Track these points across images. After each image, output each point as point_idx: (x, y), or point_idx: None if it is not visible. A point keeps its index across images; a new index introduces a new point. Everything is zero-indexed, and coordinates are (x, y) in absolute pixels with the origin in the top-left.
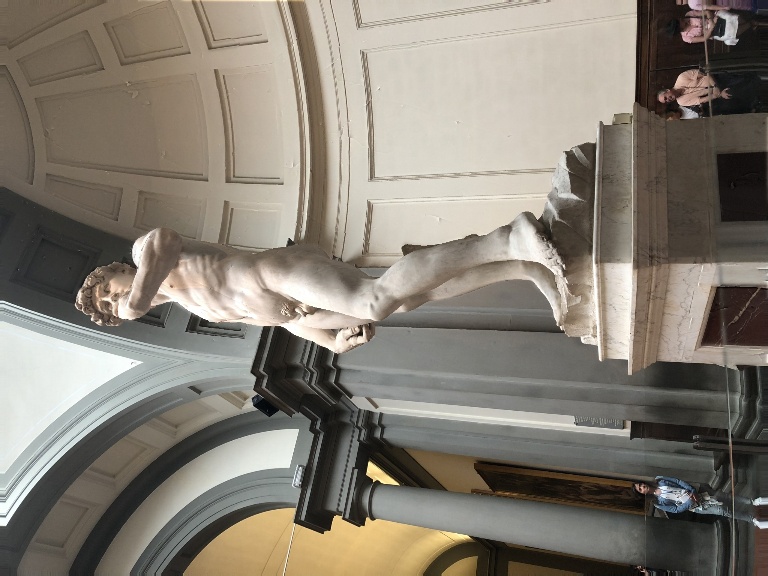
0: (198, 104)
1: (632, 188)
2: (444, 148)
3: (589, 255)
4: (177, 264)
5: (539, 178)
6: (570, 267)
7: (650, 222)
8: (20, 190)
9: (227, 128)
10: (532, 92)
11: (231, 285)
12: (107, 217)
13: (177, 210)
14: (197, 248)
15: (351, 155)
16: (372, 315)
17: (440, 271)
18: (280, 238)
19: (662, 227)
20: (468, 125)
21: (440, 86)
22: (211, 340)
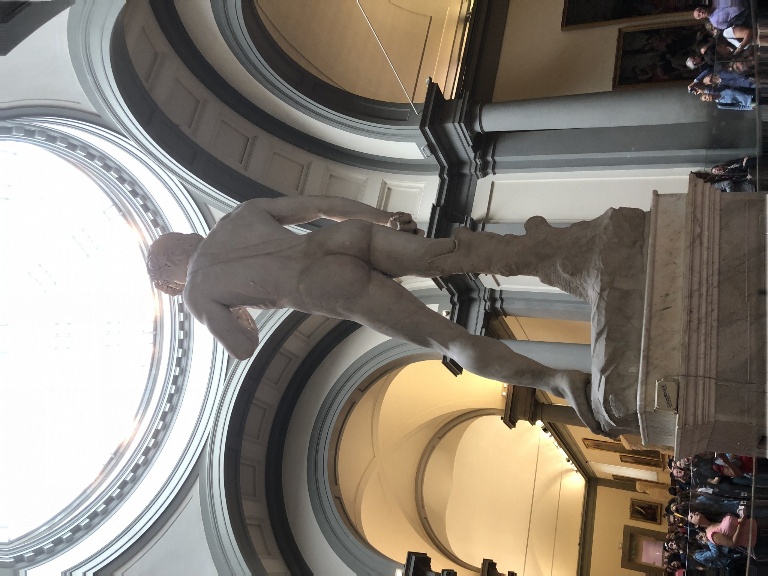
0: None
1: None
2: None
3: None
4: None
5: None
6: None
7: None
8: None
9: None
10: None
11: None
12: None
13: None
14: (243, 301)
15: None
16: None
17: None
18: None
19: None
20: None
21: None
22: None
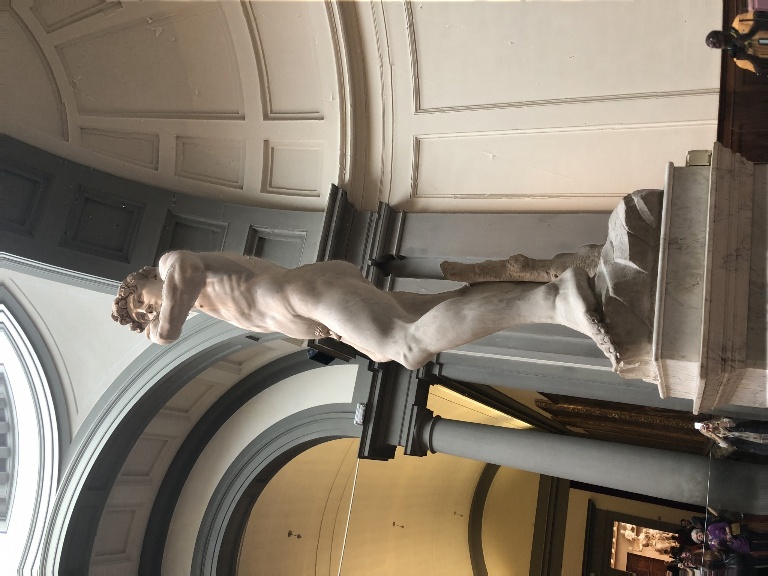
0: (226, 35)
1: (705, 260)
2: (496, 73)
3: (648, 343)
4: (204, 283)
5: (605, 107)
6: (625, 355)
7: (725, 313)
8: (57, 150)
9: (259, 60)
10: (599, 4)
11: (261, 308)
12: (147, 167)
13: (217, 153)
14: (223, 266)
15: (394, 84)
16: (406, 365)
17: (477, 330)
18: (324, 179)
19: (740, 319)
20: (523, 46)
21: (490, 0)
22: None
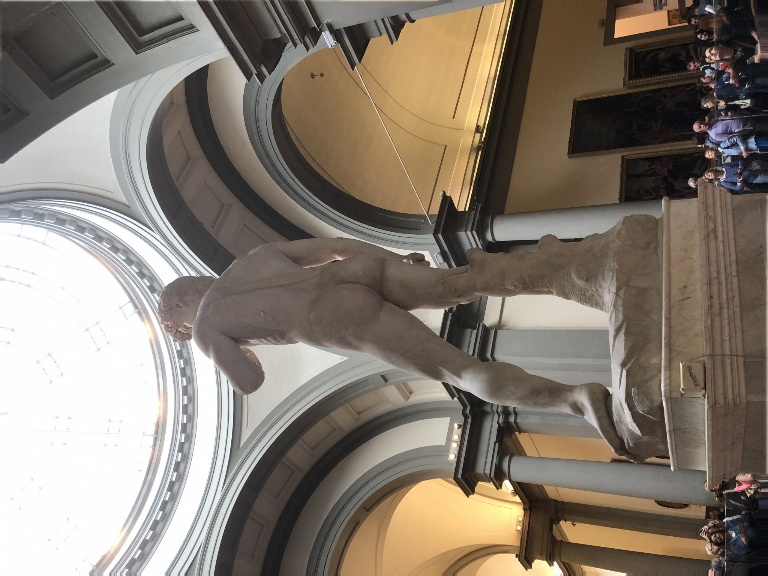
0: None
1: (706, 441)
2: None
3: None
4: (247, 341)
5: None
6: None
7: (724, 465)
8: None
9: None
10: None
11: None
12: None
13: None
14: (251, 333)
15: None
16: None
17: None
18: None
19: (736, 463)
20: None
21: None
22: (169, 49)
